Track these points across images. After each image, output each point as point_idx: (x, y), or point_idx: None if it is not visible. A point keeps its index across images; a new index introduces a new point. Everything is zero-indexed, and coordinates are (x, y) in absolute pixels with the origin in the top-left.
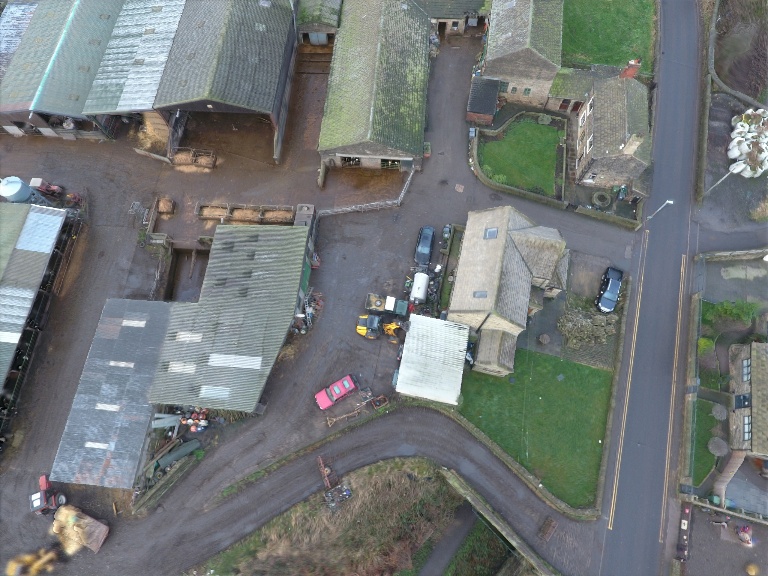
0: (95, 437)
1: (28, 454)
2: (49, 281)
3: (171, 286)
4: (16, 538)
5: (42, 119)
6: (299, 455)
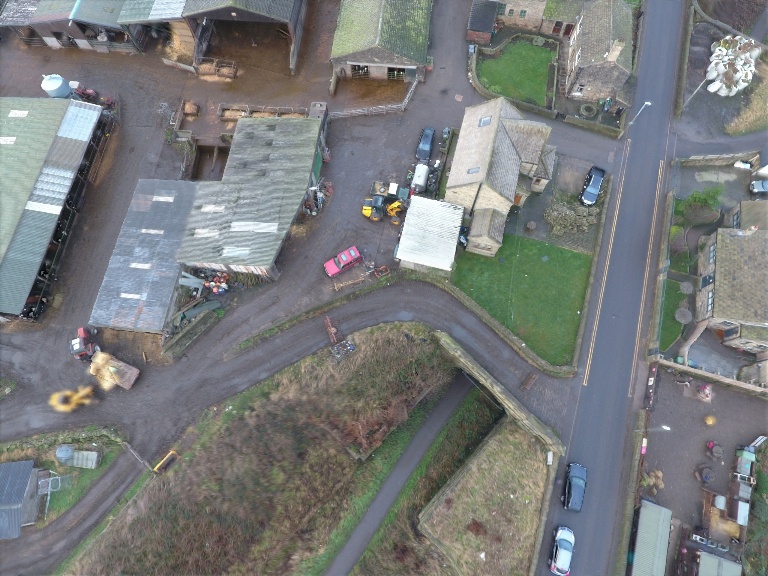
0: (129, 289)
1: (66, 314)
2: (85, 169)
3: (195, 179)
4: (56, 381)
5: (79, 29)
6: (309, 317)
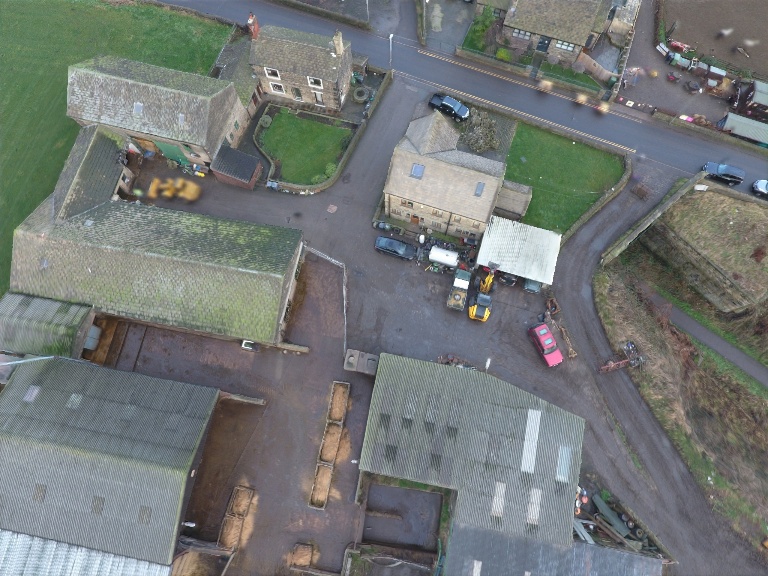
0: None
1: None
2: None
3: None
4: None
5: None
6: None
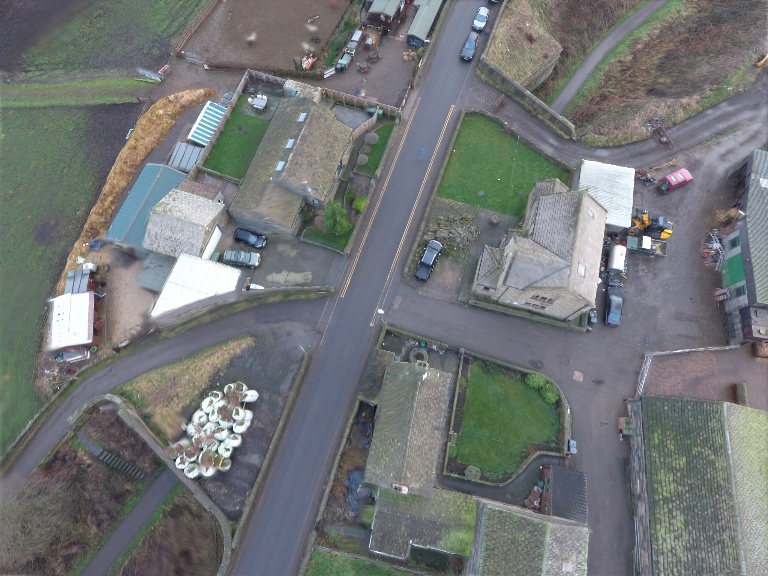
0: None
1: None
2: None
3: None
4: None
5: None
6: None
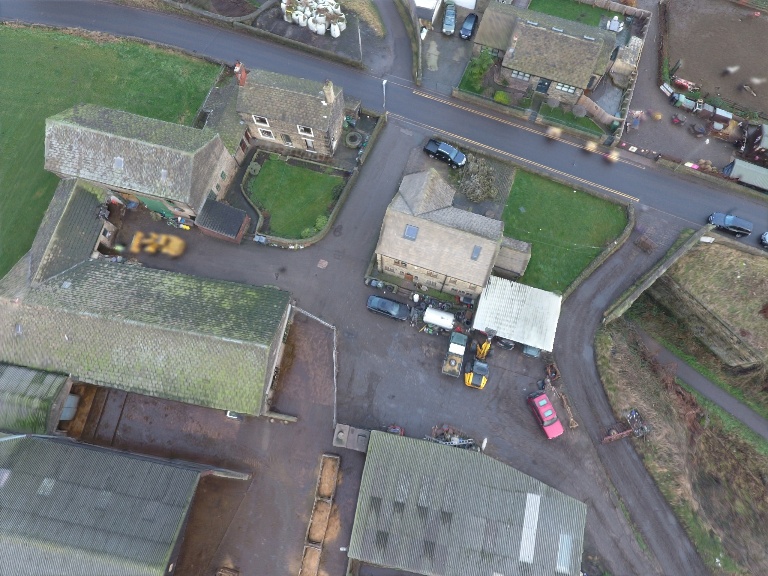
0: None
1: None
2: None
3: None
4: None
5: None
6: None
